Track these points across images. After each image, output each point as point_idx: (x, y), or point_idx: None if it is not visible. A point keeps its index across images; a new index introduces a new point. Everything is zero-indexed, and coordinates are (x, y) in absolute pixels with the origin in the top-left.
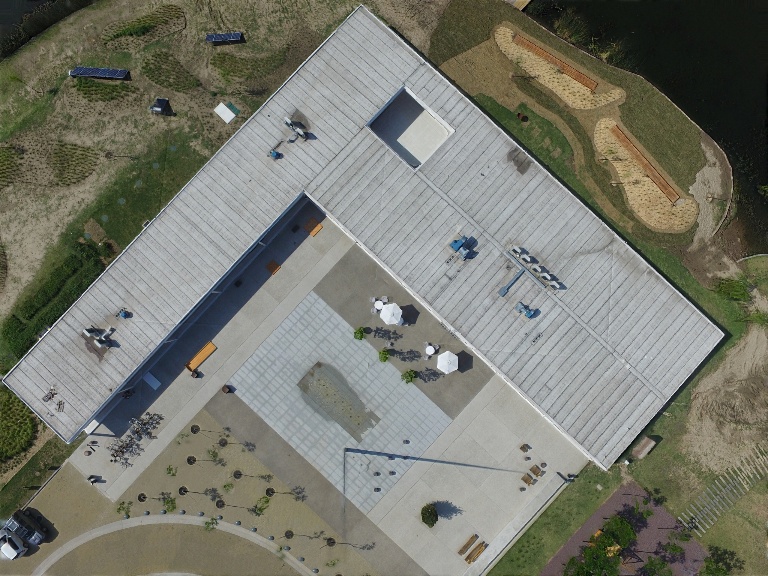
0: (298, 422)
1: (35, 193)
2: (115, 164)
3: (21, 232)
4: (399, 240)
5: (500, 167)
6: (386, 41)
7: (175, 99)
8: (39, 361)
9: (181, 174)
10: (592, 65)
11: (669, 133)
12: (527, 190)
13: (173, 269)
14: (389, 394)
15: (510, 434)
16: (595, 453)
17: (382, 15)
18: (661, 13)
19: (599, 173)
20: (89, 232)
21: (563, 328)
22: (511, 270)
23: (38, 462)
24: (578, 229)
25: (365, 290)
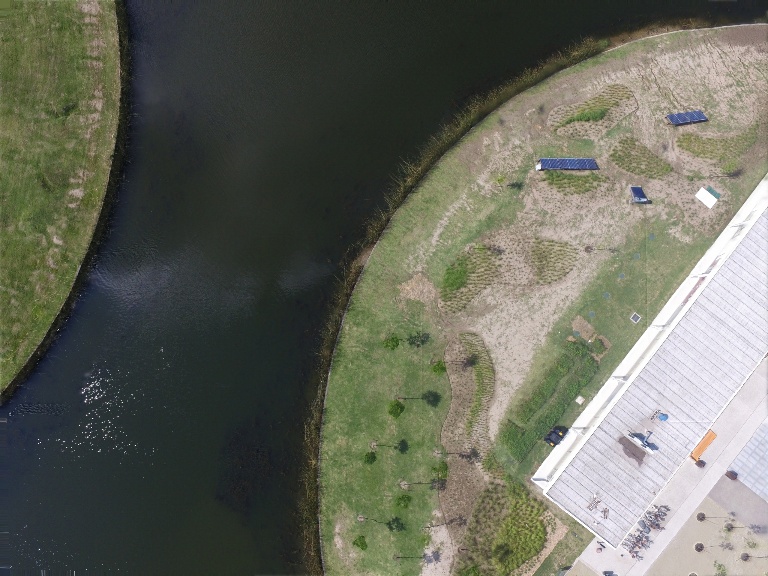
0: None
1: (514, 293)
2: (595, 258)
3: (505, 334)
4: None
5: None
6: None
7: (649, 186)
8: (579, 471)
9: (663, 263)
10: None
11: None
12: None
13: (703, 367)
14: None
15: None
16: None
17: None
18: None
19: None
20: (577, 330)
21: None
22: None
23: (552, 564)
24: None
25: None
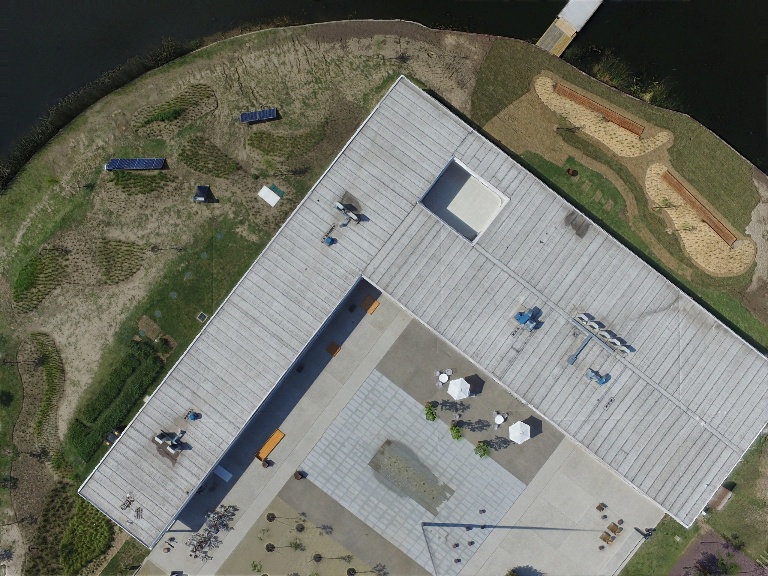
0: (373, 501)
1: (84, 294)
2: (162, 257)
3: (74, 334)
4: (462, 317)
5: (558, 232)
6: (431, 112)
7: (216, 185)
8: (112, 470)
9: (230, 262)
10: (637, 108)
11: (720, 172)
12: (588, 254)
13: (237, 366)
14: (461, 465)
15: (585, 494)
16: (676, 512)
17: (419, 78)
18: (702, 45)
19: (654, 222)
20: (143, 329)
21: (635, 391)
22: (578, 337)
23: (118, 563)
24: (642, 289)
25: (428, 364)
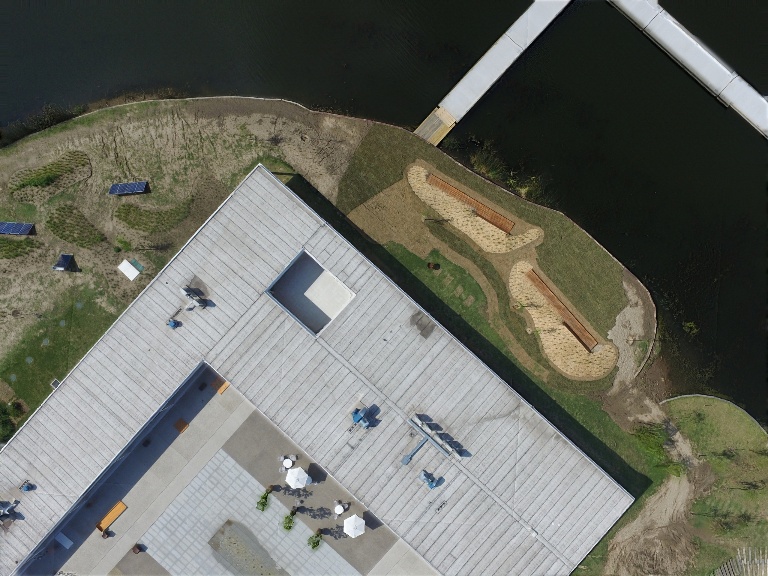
0: None
1: None
2: (22, 322)
3: None
4: (300, 409)
5: (403, 331)
6: (285, 202)
7: (80, 254)
8: None
9: (88, 332)
10: (509, 203)
11: (589, 274)
12: (431, 355)
13: (74, 441)
14: (300, 551)
15: None
16: None
17: (288, 162)
18: (584, 142)
19: (514, 320)
20: None
21: (468, 496)
22: (415, 437)
23: None
24: (483, 394)
25: (274, 447)
